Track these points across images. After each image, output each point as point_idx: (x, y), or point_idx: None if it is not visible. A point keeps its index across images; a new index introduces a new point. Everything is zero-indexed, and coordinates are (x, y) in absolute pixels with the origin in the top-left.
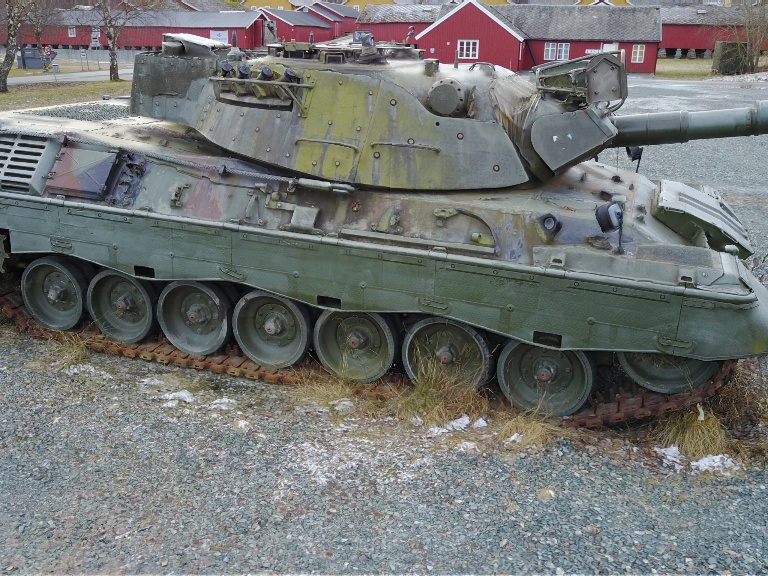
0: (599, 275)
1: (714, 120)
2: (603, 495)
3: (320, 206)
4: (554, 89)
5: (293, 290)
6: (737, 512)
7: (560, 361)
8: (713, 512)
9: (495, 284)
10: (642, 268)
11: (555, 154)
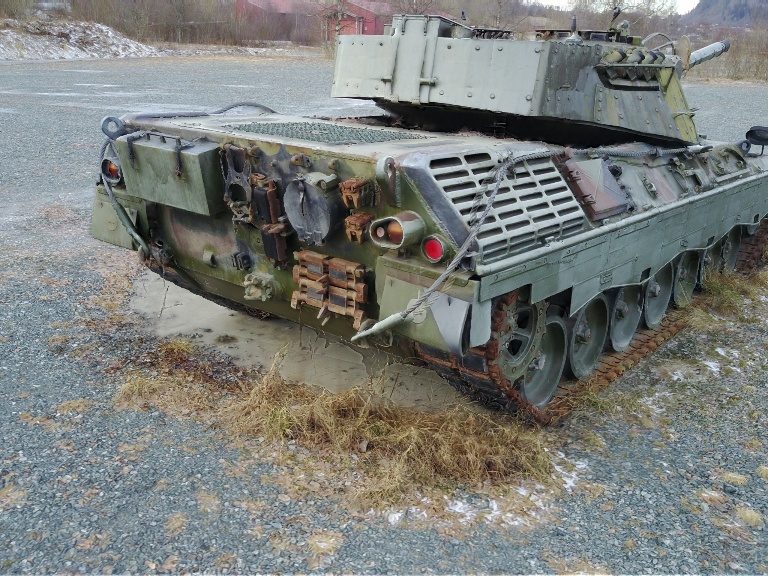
0: None
1: None
2: None
3: None
4: None
5: None
6: None
7: None
8: None
9: None
10: (767, 162)
11: None
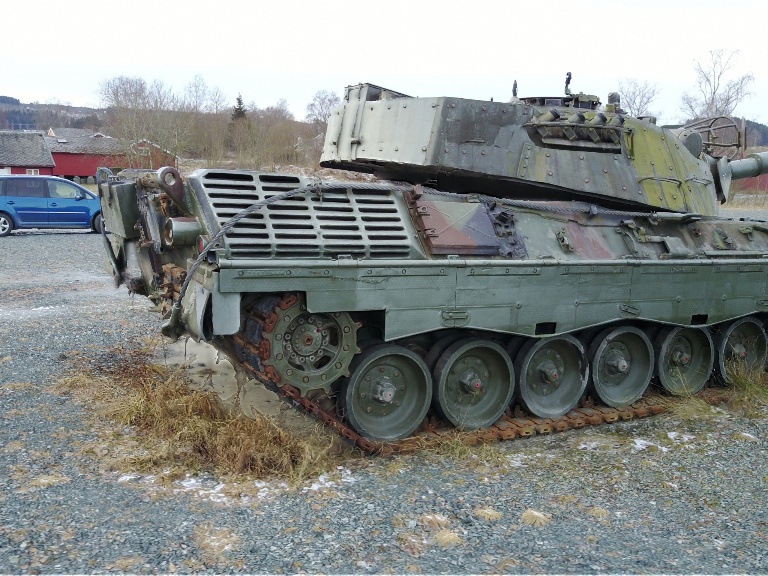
0: None
1: (743, 166)
2: None
3: (673, 236)
4: None
5: (675, 315)
6: None
7: None
8: None
9: None
10: None
11: None
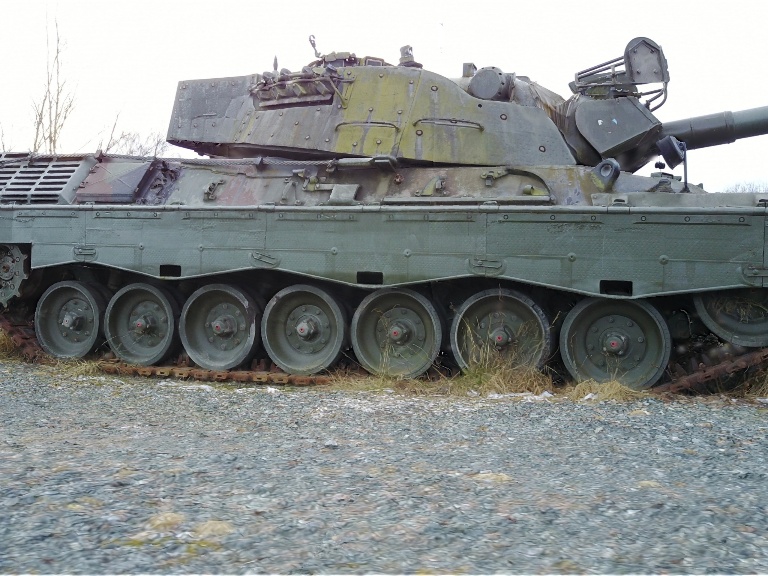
0: (667, 207)
1: (759, 113)
2: (709, 415)
3: (360, 184)
4: (594, 84)
5: (330, 269)
6: None
7: (630, 331)
8: None
9: (553, 231)
10: (714, 199)
11: (601, 137)
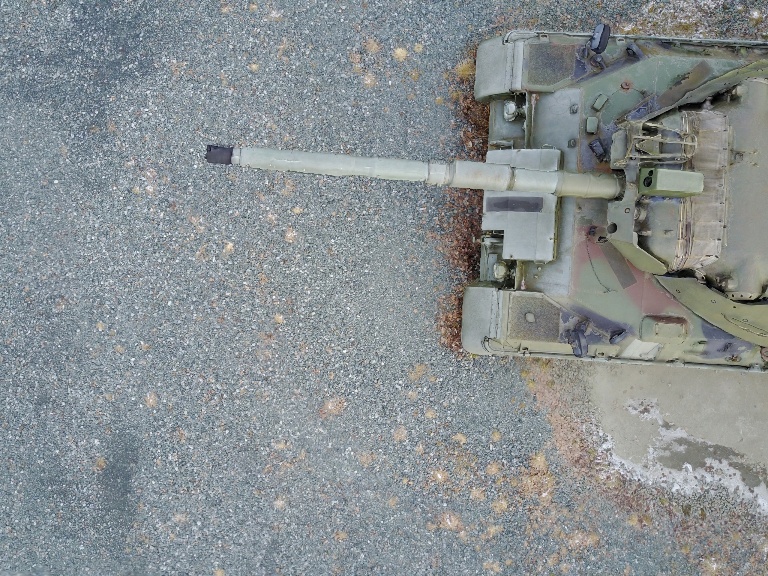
0: None
1: None
2: (557, 0)
3: None
4: None
5: None
6: (496, 5)
7: None
8: (506, 2)
9: None
10: (571, 42)
11: None
